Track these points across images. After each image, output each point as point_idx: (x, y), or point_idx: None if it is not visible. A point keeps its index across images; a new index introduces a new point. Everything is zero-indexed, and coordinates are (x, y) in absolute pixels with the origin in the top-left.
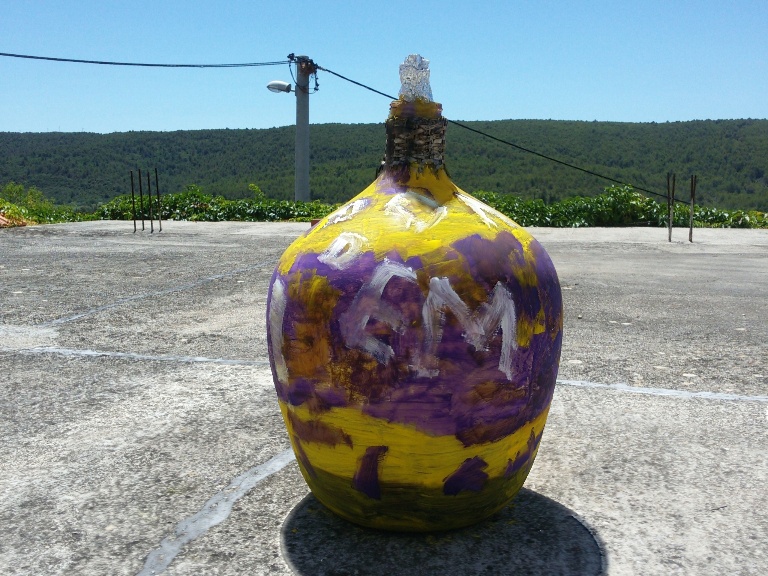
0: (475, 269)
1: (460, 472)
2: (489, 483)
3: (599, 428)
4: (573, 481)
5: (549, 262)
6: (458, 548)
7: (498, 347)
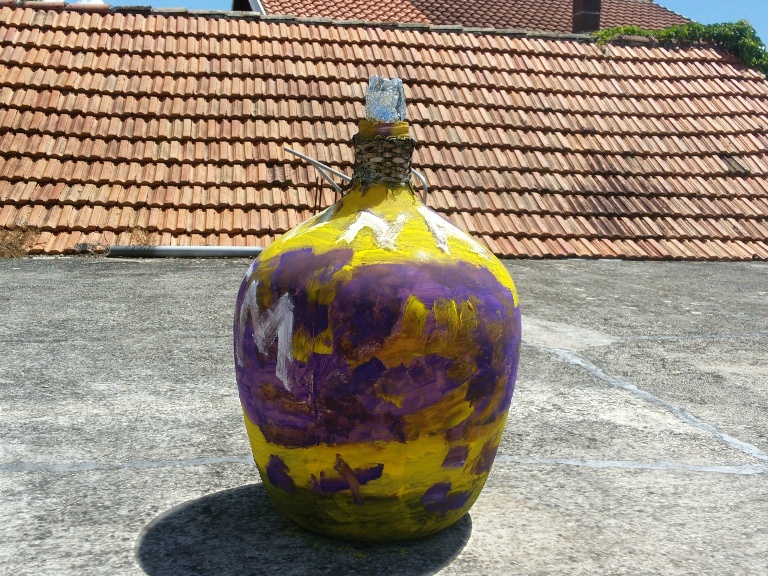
0: (276, 278)
1: (271, 465)
2: (298, 490)
3: (741, 575)
4: (511, 574)
5: (391, 288)
6: (284, 541)
7: (275, 354)
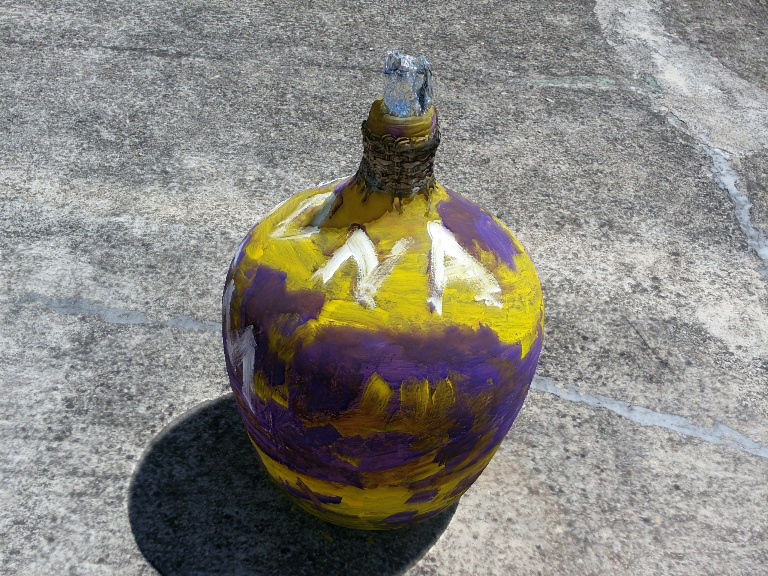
0: (247, 299)
1: None
2: None
3: None
4: None
5: (355, 361)
6: (267, 495)
7: (241, 376)
